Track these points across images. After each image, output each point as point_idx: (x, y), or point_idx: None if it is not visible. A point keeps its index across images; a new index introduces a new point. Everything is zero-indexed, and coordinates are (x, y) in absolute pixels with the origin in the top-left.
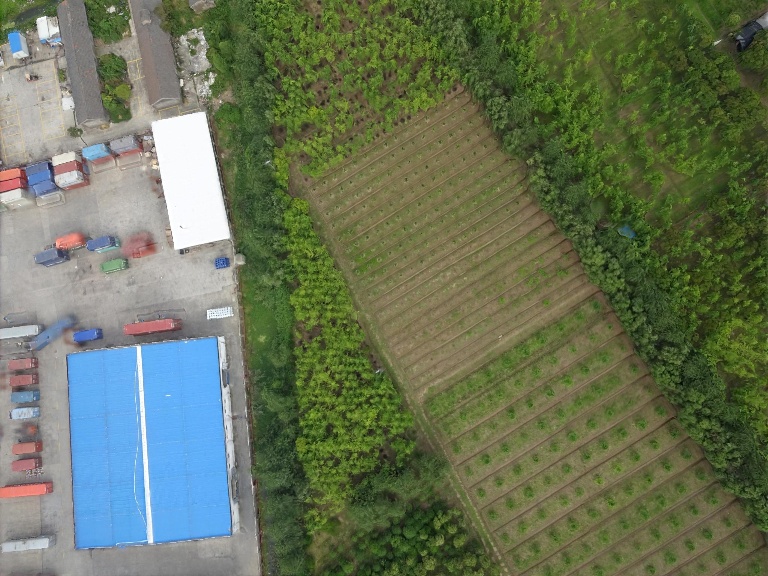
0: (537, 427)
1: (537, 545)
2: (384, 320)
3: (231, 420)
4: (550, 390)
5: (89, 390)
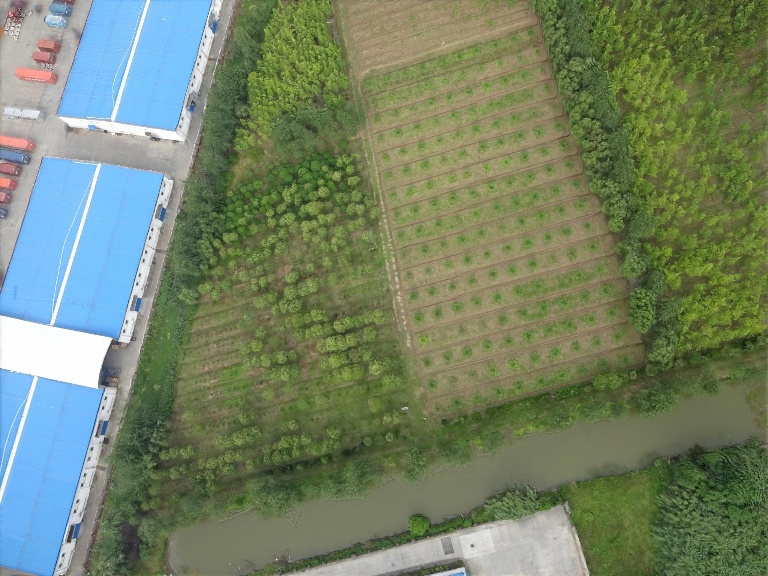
0: (449, 117)
1: (418, 208)
2: (353, 12)
3: (207, 60)
4: None
5: (107, 5)
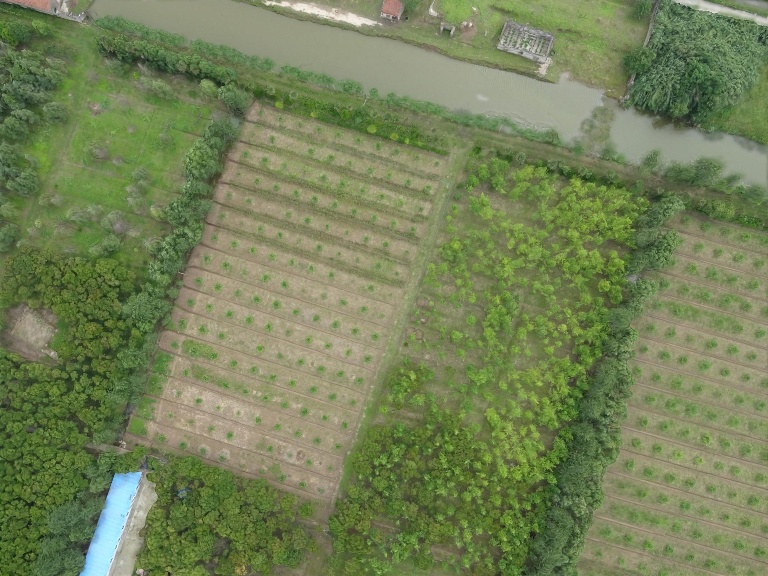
0: None
1: None
2: None
3: None
4: (668, 553)
5: None
